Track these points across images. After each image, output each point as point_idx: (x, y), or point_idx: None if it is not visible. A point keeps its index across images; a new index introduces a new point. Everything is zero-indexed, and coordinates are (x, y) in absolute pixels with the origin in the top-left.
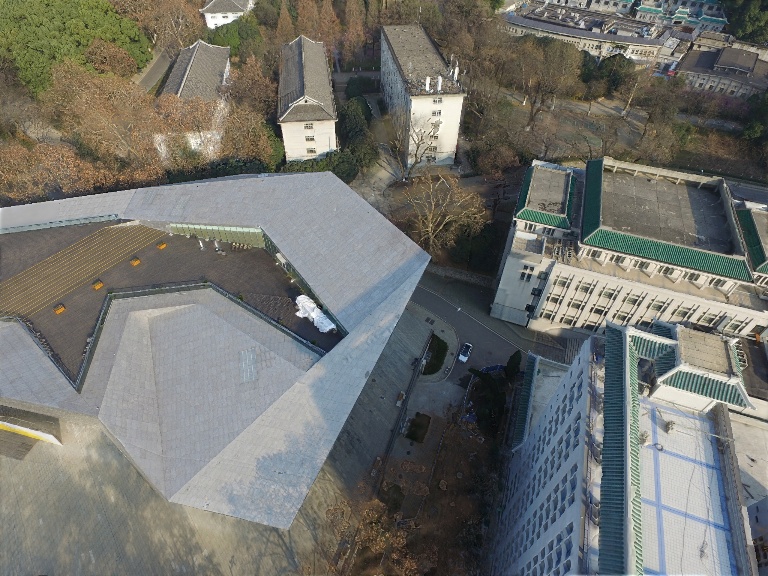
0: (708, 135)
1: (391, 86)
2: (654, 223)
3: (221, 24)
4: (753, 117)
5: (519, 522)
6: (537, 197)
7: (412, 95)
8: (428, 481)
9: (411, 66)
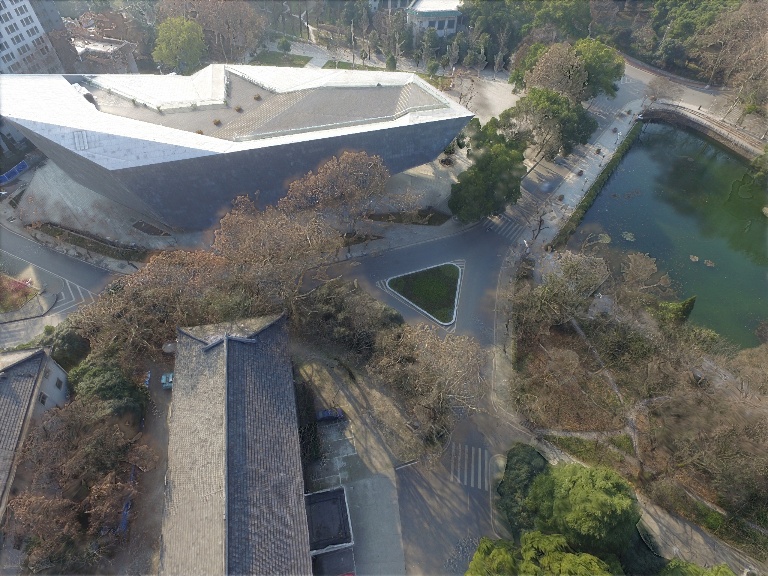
0: None
1: None
2: None
3: None
4: None
5: None
6: None
7: None
8: None
9: None
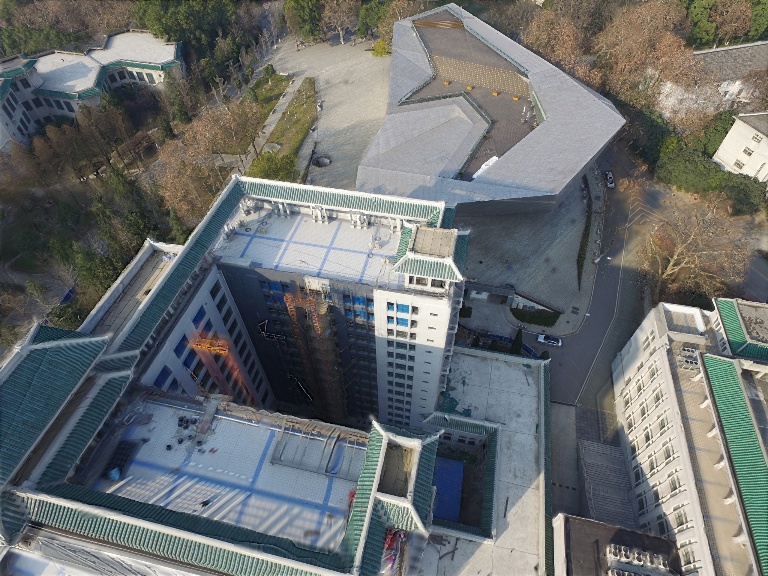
0: None
1: None
2: None
3: None
4: None
5: None
6: None
7: None
8: None
9: None
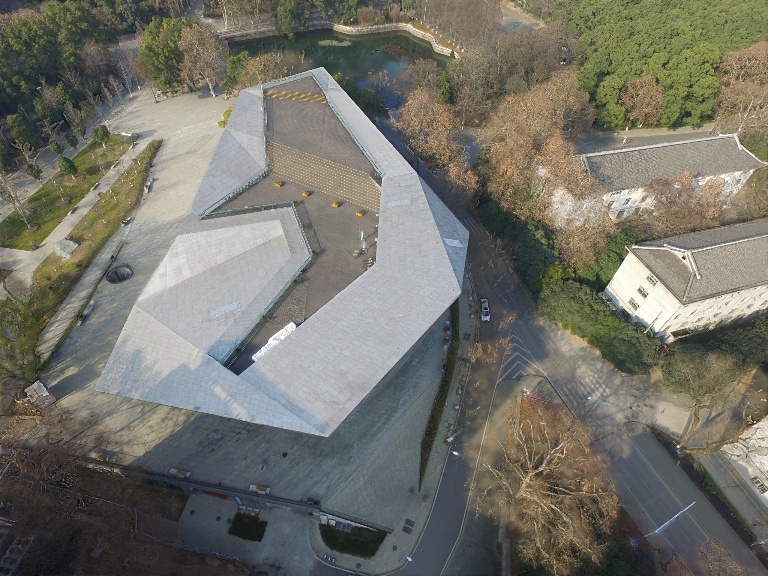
0: None
1: None
2: None
3: None
4: None
5: None
6: None
7: None
8: None
9: None
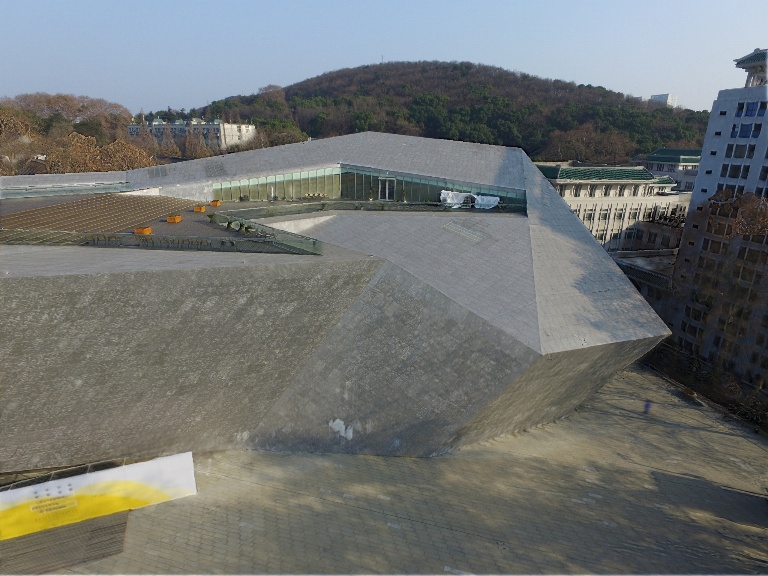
0: None
1: None
2: None
3: None
4: None
5: (767, 275)
6: None
7: None
8: None
9: None
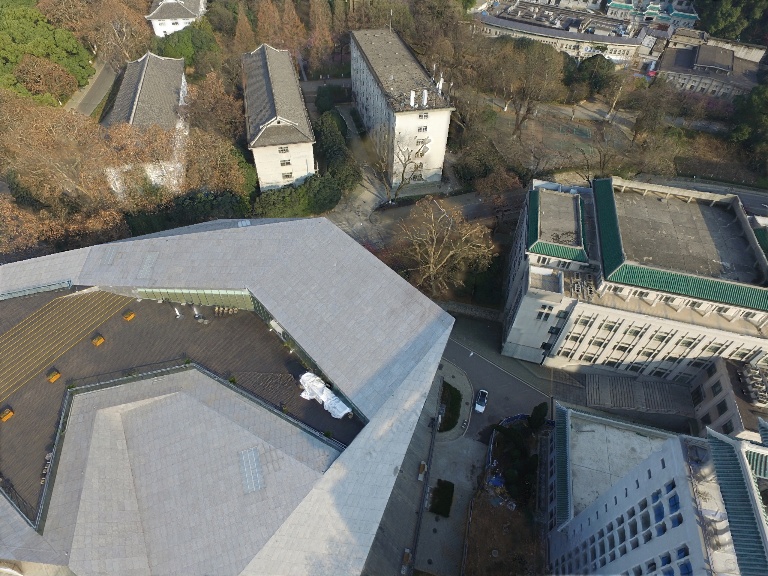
0: (694, 137)
1: (367, 97)
2: (675, 250)
3: (171, 31)
4: (739, 118)
5: None
6: (548, 226)
7: (396, 111)
8: (461, 565)
9: (390, 77)
